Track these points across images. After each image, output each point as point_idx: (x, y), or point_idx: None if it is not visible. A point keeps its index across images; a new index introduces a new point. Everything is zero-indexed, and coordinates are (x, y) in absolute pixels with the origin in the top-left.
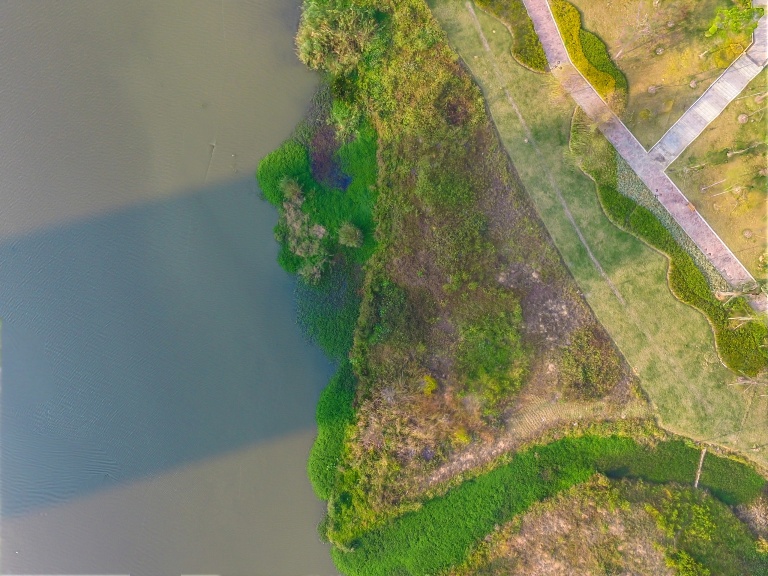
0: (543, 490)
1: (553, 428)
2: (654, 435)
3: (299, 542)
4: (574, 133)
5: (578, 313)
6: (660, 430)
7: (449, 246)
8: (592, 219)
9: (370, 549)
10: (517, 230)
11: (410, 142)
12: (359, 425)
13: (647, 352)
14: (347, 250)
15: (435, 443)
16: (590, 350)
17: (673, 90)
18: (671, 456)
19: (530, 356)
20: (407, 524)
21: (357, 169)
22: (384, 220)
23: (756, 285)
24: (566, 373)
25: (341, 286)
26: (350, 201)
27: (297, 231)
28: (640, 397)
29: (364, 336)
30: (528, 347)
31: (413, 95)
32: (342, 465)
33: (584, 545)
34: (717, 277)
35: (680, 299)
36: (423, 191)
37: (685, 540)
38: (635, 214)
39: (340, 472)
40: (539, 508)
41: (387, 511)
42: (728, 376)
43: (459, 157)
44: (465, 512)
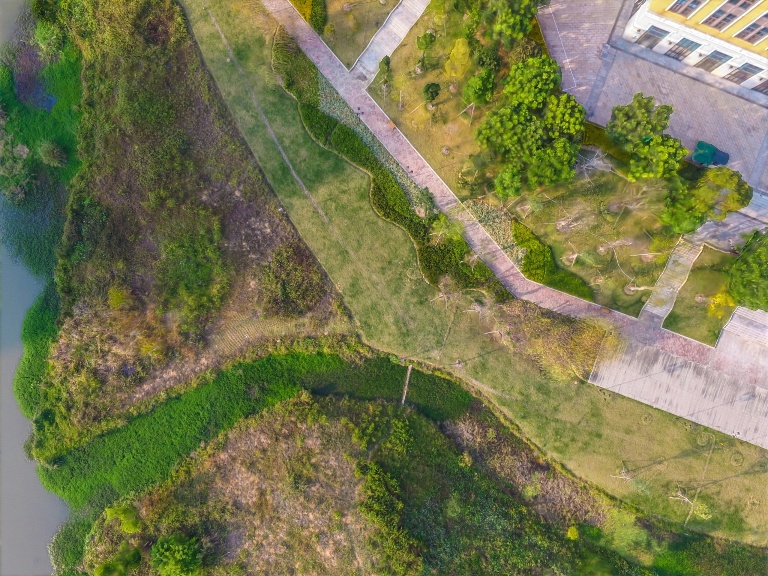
0: (249, 407)
1: (256, 345)
2: (360, 352)
3: (4, 460)
4: (275, 52)
5: (281, 231)
6: (364, 346)
7: (151, 165)
8: (295, 137)
9: (76, 467)
10: (219, 149)
11: (112, 62)
12: (60, 342)
13: (350, 269)
14: (51, 170)
15: (134, 359)
16: (290, 266)
17: (366, 7)
18: (377, 373)
19: (231, 273)
20: (112, 441)
21: (62, 90)
22: (86, 139)
23: (458, 202)
24: (266, 289)
25: (46, 206)
26: (54, 121)
27: (1, 151)
28: (342, 313)
29: (62, 253)
30: (228, 264)
31: (113, 15)
32: (45, 383)
33: (279, 458)
34: (418, 194)
35: (381, 216)
36: (121, 109)
37: (379, 452)
38: (336, 132)
39: (43, 390)
40: (244, 424)
41: (90, 428)
42: (430, 292)
43: (160, 76)
44: (171, 429)
